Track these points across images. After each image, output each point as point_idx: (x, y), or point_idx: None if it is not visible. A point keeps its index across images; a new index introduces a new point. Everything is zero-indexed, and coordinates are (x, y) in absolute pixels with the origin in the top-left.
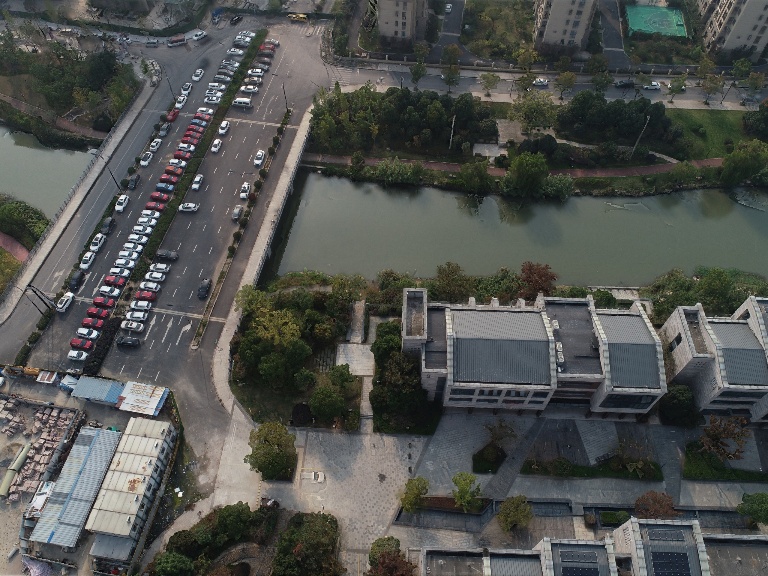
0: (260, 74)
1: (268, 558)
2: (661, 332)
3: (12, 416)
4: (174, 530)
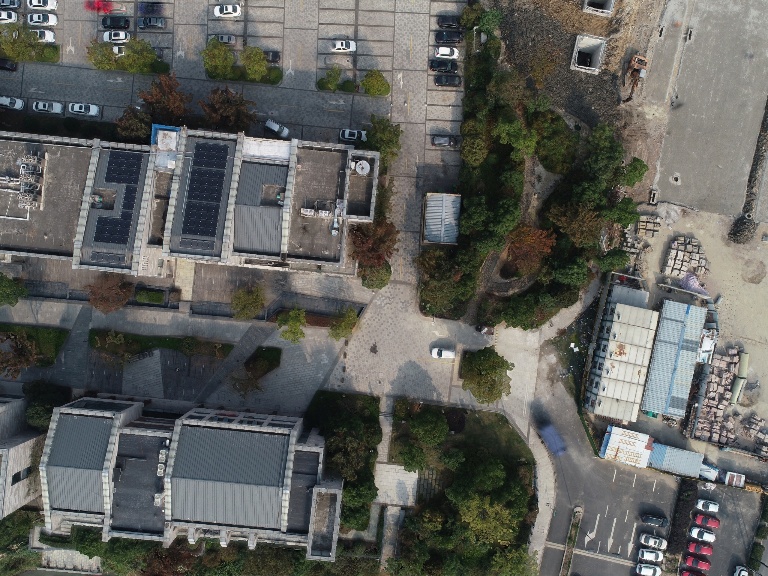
0: None
1: (484, 282)
2: (33, 494)
3: (759, 436)
4: (574, 312)
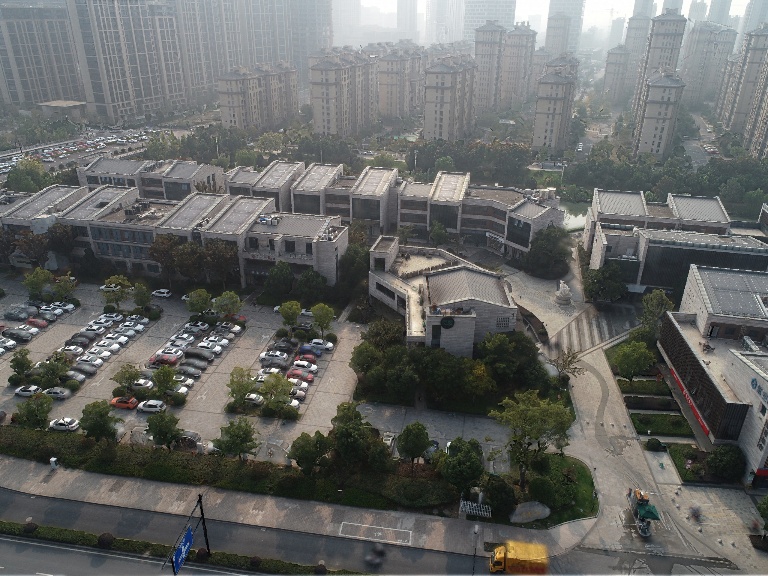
0: (145, 138)
1: None
2: None
3: None
4: None
